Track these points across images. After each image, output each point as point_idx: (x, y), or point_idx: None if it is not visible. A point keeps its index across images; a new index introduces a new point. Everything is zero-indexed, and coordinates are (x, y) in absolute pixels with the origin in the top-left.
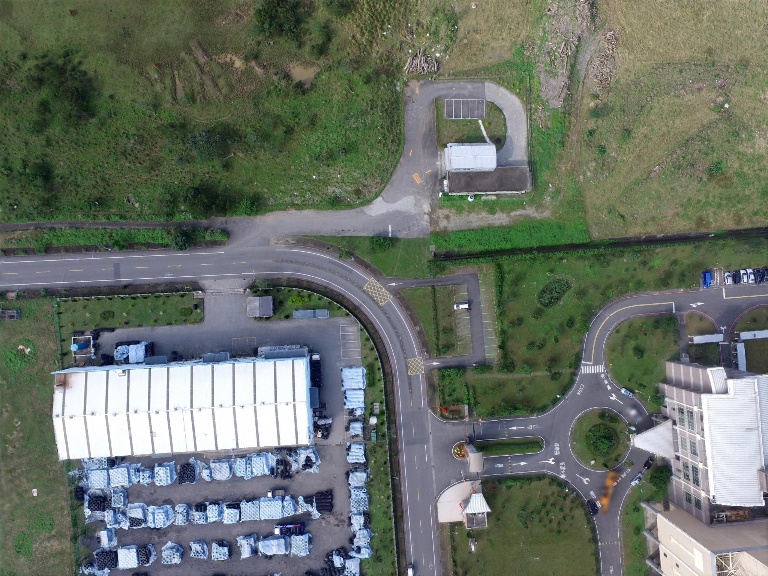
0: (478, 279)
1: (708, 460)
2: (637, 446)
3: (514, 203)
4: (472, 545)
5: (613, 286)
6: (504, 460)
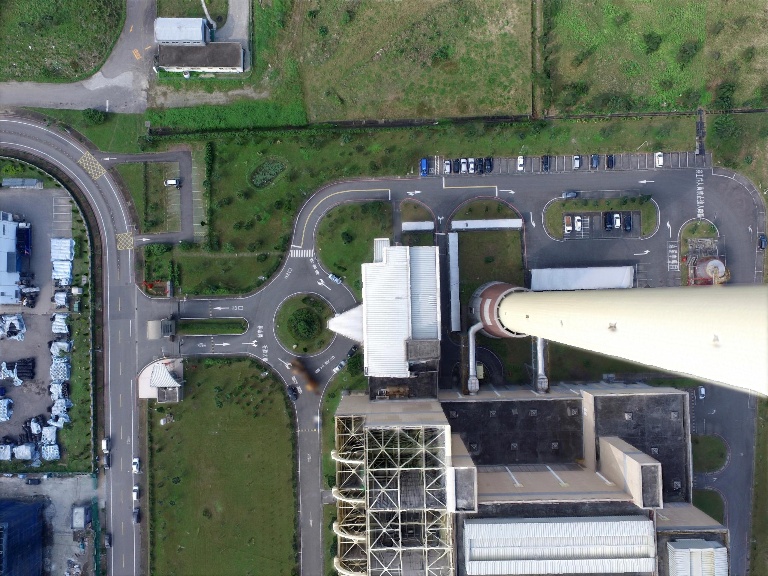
0: (191, 157)
1: (364, 331)
2: (331, 329)
3: (231, 82)
4: (161, 419)
5: (327, 170)
6: (207, 340)
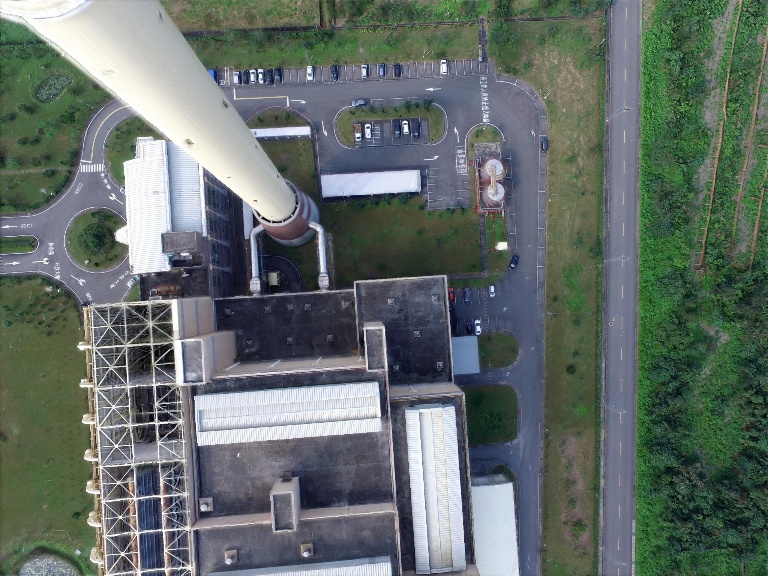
0: None
1: (127, 229)
2: (118, 240)
3: None
4: None
5: None
6: None
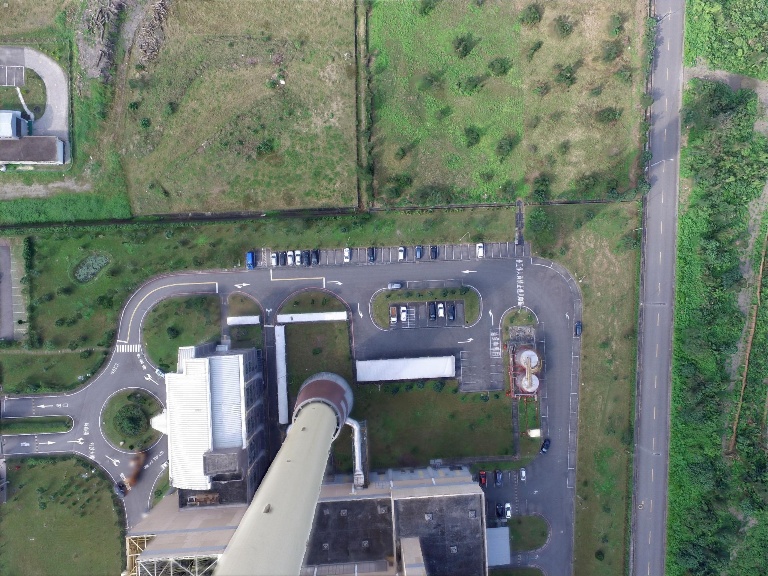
0: (10, 252)
1: (168, 441)
2: (154, 428)
3: (51, 175)
4: None
5: None
6: (30, 439)
